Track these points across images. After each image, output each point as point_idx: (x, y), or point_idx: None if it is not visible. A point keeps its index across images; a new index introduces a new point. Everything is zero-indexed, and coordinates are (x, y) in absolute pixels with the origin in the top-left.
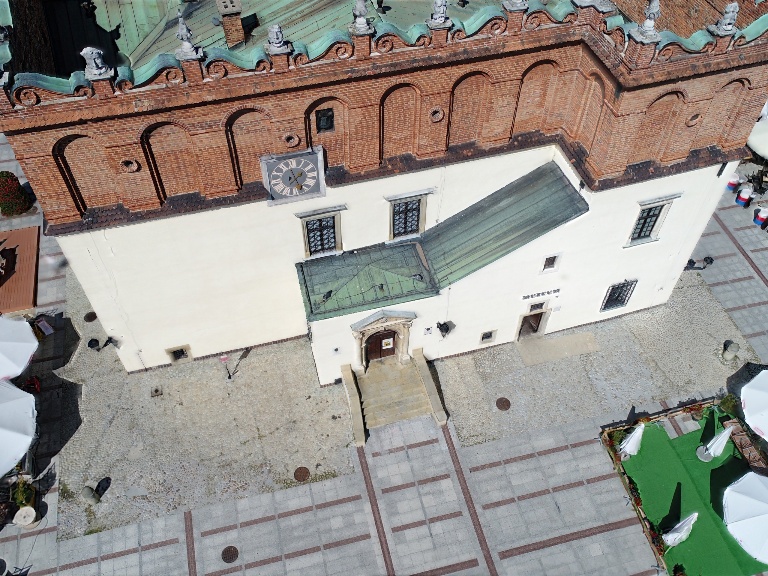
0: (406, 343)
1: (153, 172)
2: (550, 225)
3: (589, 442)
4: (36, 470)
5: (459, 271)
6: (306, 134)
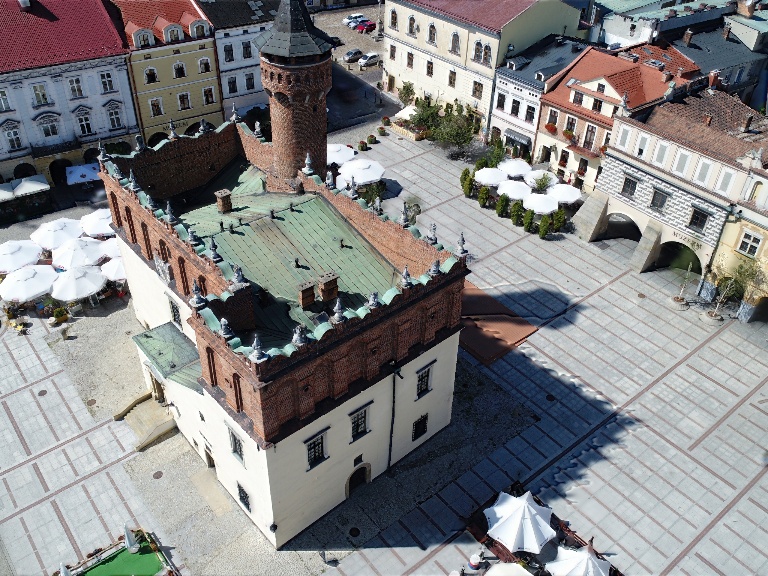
0: (165, 400)
1: (132, 227)
2: (196, 387)
3: None
4: (78, 315)
5: (177, 376)
6: (163, 253)
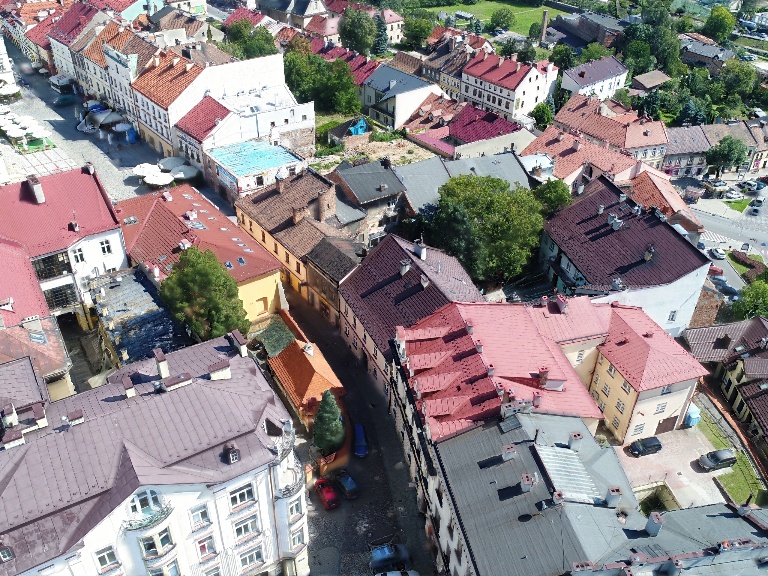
0: None
1: None
2: None
3: None
4: None
5: None
6: None
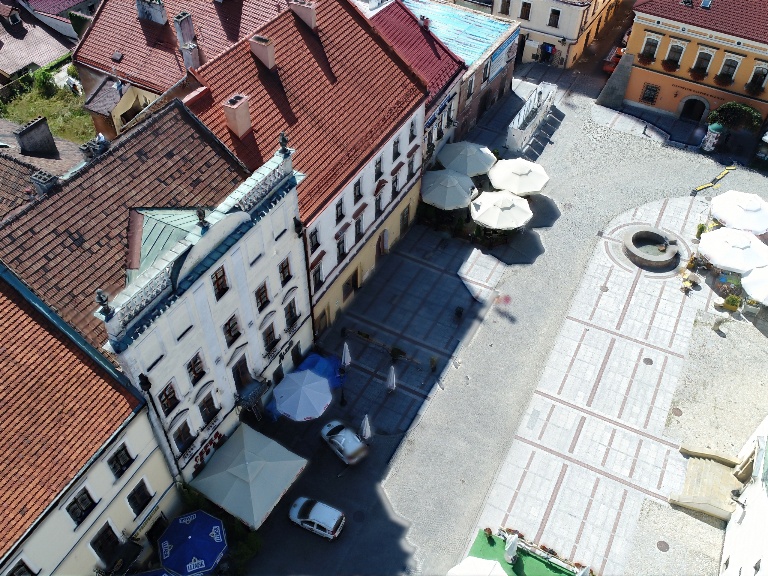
0: None
1: None
2: None
3: (602, 573)
4: (748, 315)
5: None
6: None
